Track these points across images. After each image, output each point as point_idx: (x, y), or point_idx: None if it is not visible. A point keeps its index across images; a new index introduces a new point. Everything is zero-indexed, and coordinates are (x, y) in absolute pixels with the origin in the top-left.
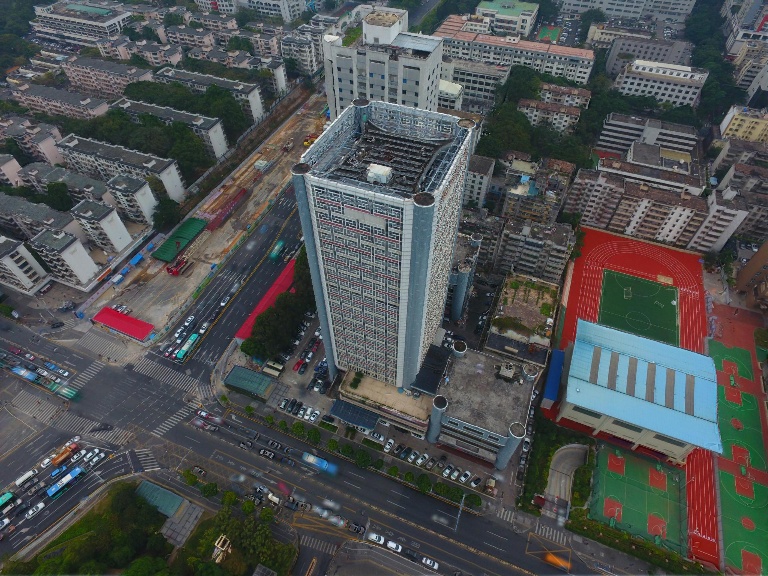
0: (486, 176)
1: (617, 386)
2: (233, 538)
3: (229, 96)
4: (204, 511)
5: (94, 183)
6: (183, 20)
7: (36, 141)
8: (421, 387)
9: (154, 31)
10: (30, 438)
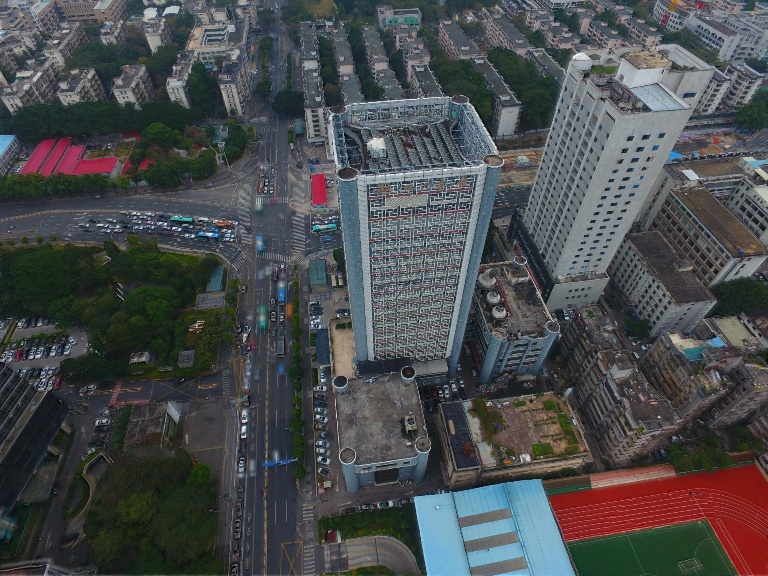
0: (674, 304)
1: (474, 553)
2: (203, 327)
3: (555, 92)
4: (221, 307)
5: None
6: (618, 20)
7: (409, 58)
8: (360, 370)
9: (580, 19)
10: (226, 206)
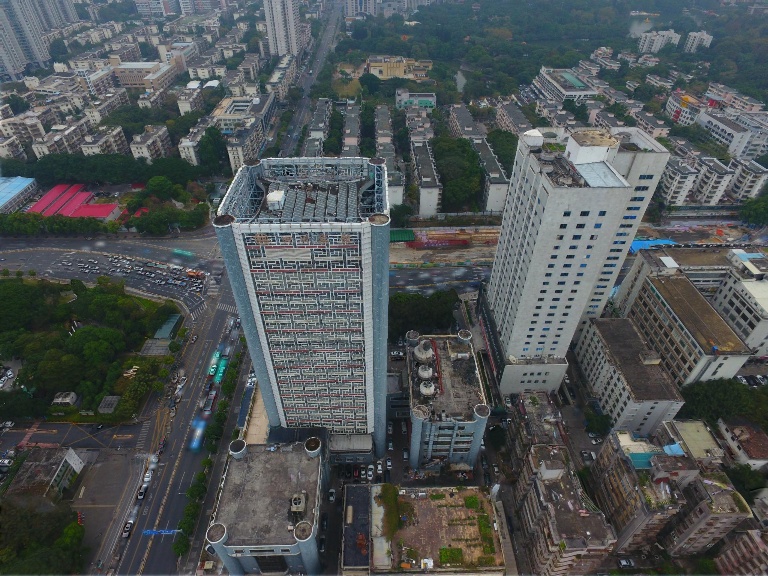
0: (633, 400)
1: None
2: None
3: None
4: (165, 355)
5: (390, 170)
6: (626, 112)
7: (412, 135)
8: (270, 436)
9: (588, 110)
10: (205, 257)
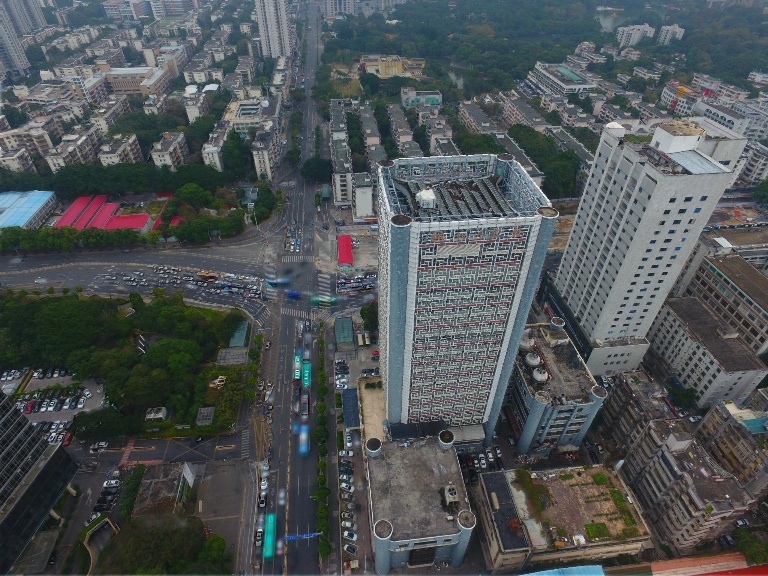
0: (724, 372)
1: None
2: (225, 383)
3: (575, 164)
4: (243, 363)
5: None
6: (628, 104)
7: (432, 132)
8: (393, 433)
9: (593, 102)
10: (253, 263)
